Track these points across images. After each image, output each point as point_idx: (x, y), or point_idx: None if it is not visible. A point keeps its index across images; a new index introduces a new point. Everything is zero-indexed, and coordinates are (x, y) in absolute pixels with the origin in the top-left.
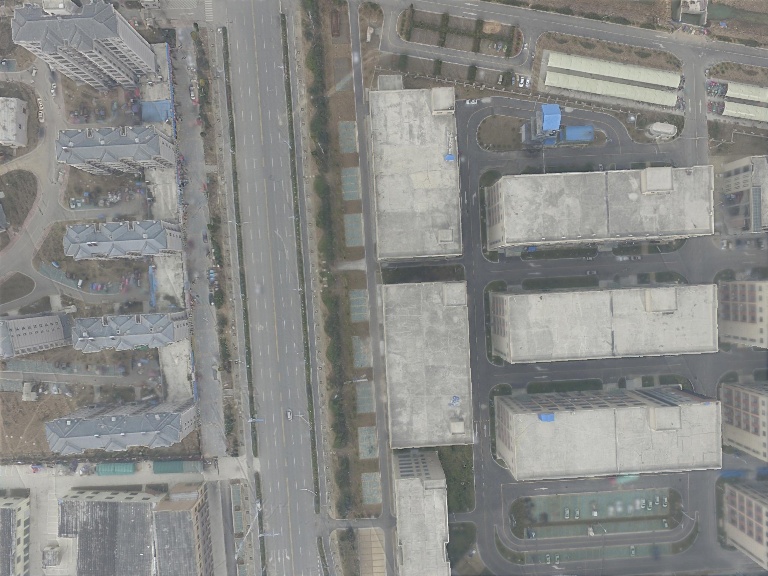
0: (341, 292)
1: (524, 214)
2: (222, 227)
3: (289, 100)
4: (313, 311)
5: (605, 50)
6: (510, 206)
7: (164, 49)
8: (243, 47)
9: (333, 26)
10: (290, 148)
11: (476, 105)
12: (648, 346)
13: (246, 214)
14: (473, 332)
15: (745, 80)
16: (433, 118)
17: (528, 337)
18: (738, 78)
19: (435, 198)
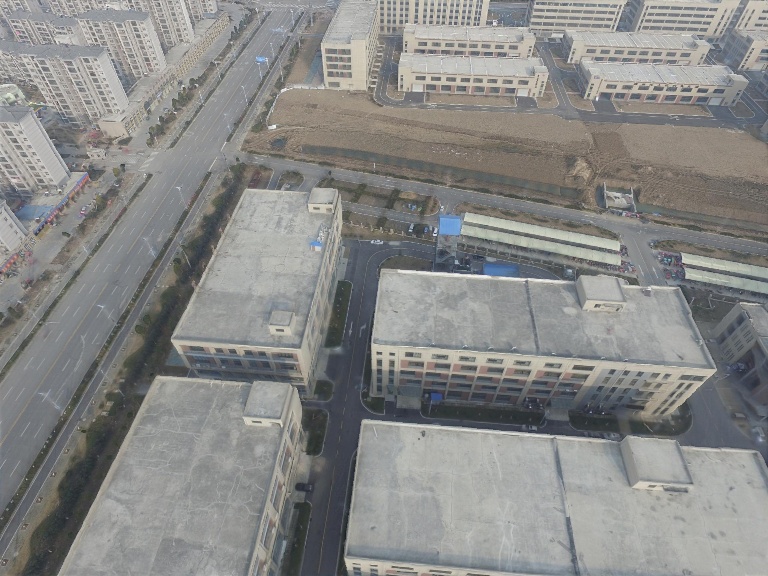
0: (122, 425)
1: (407, 313)
2: (18, 323)
3: (179, 223)
4: (62, 450)
5: (529, 219)
6: (387, 302)
7: (81, 176)
8: (160, 187)
9: (251, 180)
10: (154, 257)
11: (382, 245)
12: (655, 567)
13: (59, 314)
14: (319, 530)
15: (702, 255)
16: (309, 215)
17: (391, 505)
18: (692, 253)
19: (285, 283)
